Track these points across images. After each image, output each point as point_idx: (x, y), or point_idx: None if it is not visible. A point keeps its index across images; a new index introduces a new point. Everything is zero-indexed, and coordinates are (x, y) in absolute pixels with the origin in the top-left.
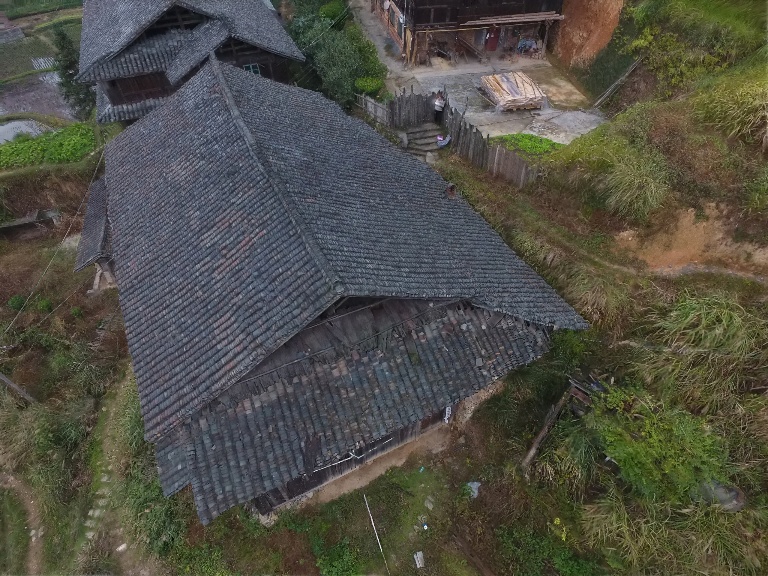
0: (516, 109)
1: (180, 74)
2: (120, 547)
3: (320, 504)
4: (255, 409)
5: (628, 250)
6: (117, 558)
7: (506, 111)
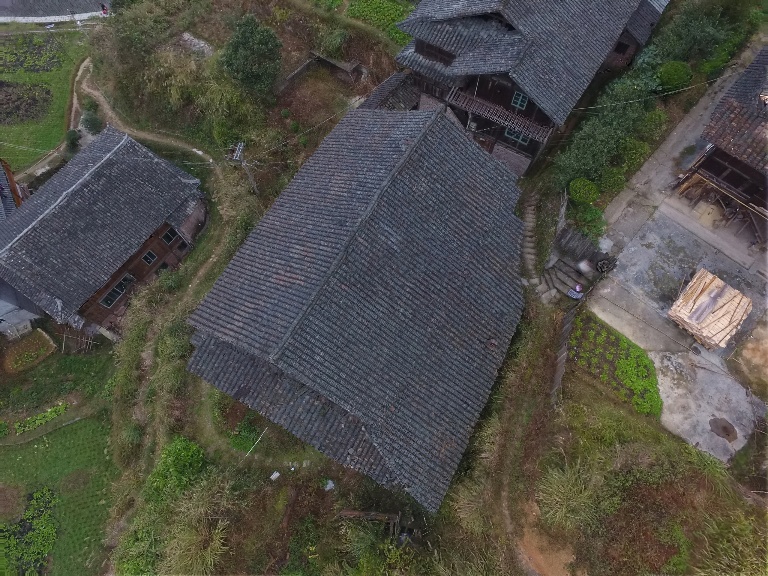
0: (683, 328)
1: (457, 72)
2: None
3: None
4: None
5: (525, 516)
6: None
7: (672, 320)
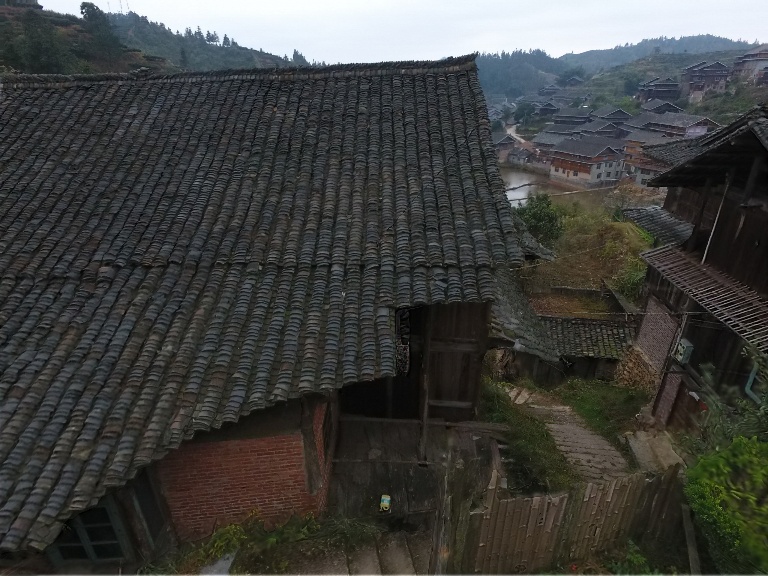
0: None
1: None
2: None
3: None
4: None
5: None
6: None
7: None
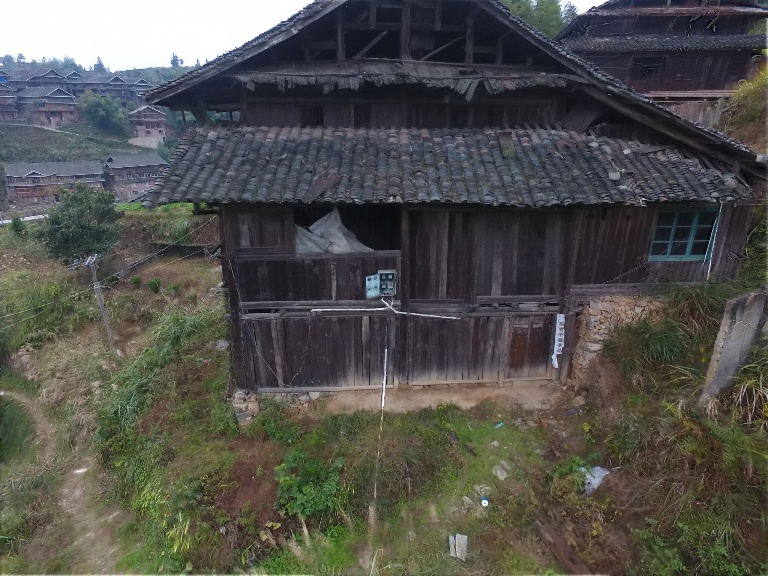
0: None
1: None
2: (79, 470)
3: (324, 418)
4: (277, 142)
5: None
6: (67, 476)
7: None
